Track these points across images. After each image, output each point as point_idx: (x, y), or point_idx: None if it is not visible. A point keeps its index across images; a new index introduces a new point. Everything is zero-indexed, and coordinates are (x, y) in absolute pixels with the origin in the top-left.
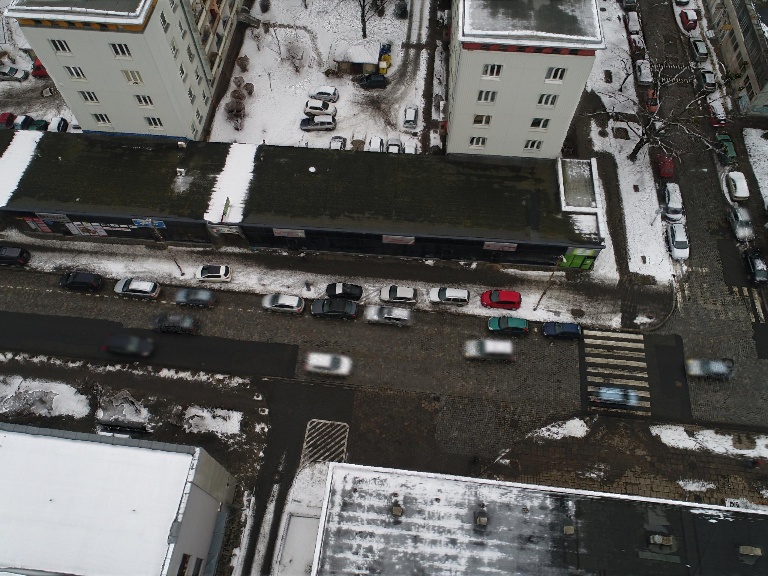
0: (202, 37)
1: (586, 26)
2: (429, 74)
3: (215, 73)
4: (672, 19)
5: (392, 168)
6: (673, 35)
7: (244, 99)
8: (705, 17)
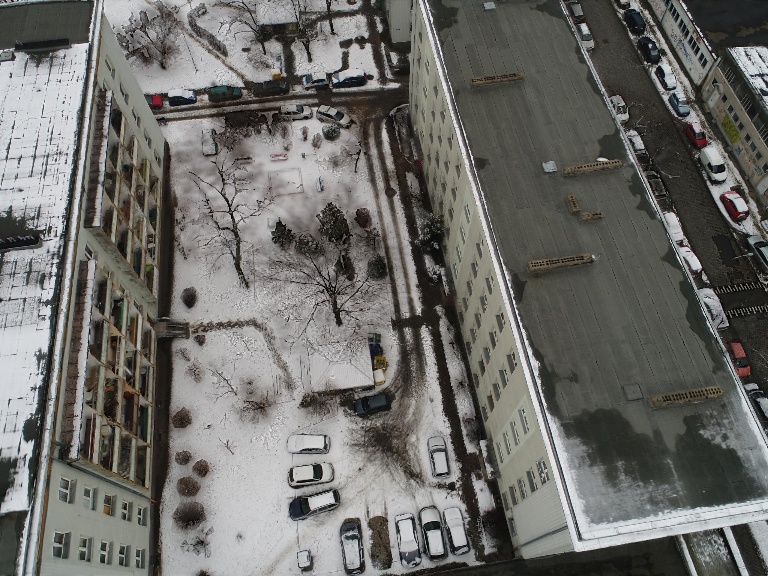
0: (120, 451)
1: (757, 471)
2: (442, 370)
3: (149, 474)
4: (714, 208)
5: None
6: (724, 234)
7: (198, 490)
8: (751, 197)
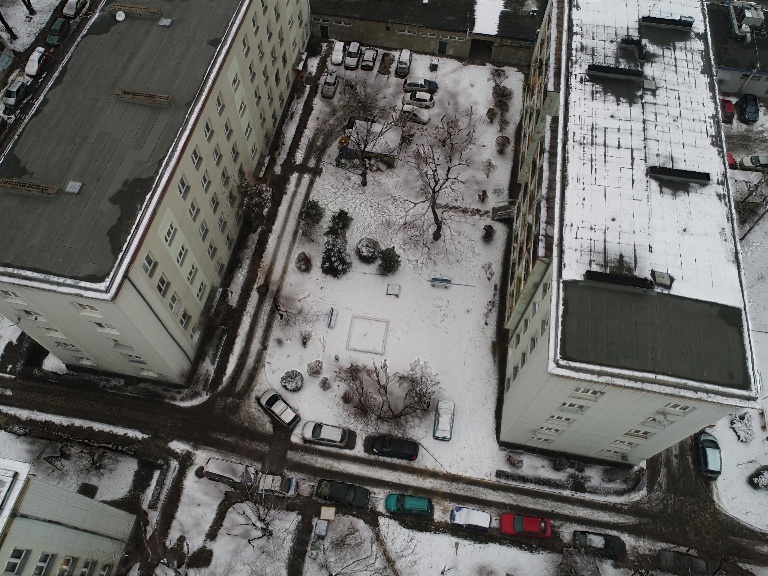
0: None
1: None
2: (300, 132)
3: None
4: None
5: (359, 5)
6: None
7: None
8: None
